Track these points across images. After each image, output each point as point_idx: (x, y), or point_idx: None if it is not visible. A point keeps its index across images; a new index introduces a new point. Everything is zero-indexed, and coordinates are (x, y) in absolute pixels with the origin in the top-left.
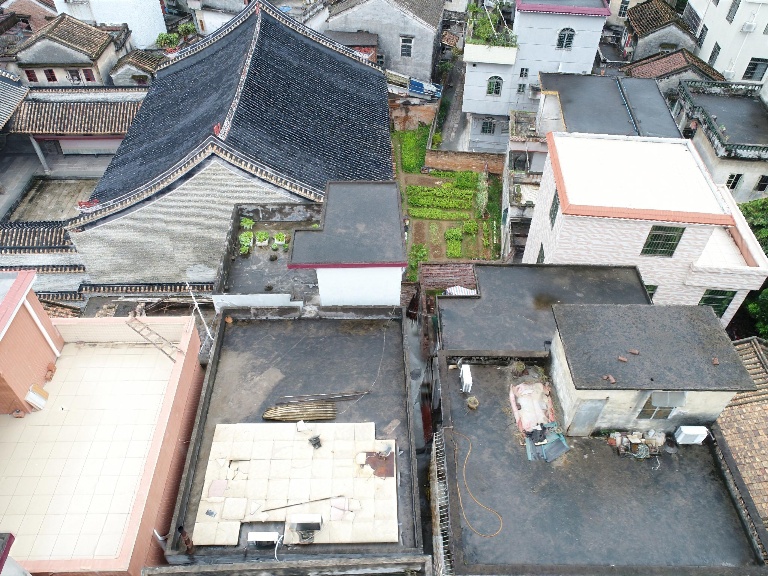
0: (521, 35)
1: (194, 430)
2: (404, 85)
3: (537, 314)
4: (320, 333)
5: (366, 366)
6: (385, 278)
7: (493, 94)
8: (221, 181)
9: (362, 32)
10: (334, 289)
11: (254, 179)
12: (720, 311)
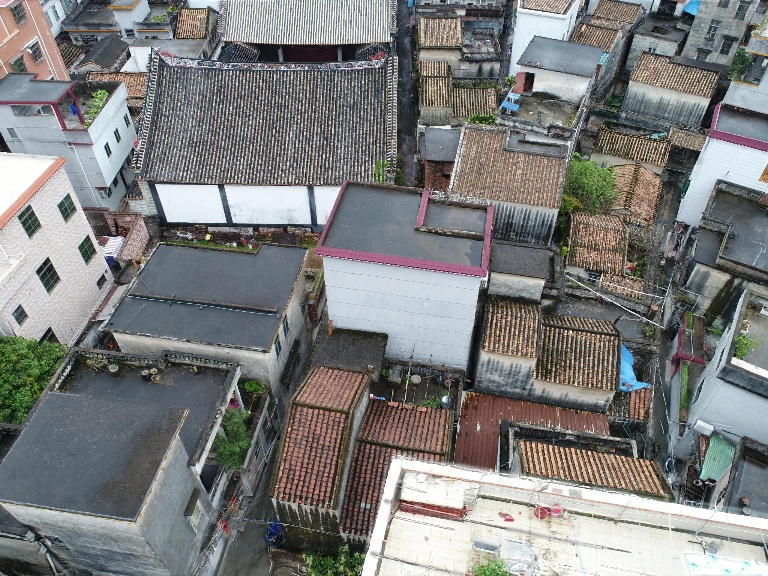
0: None
1: None
2: None
3: None
4: None
5: None
6: None
7: None
8: None
9: None
10: None
11: None
12: None
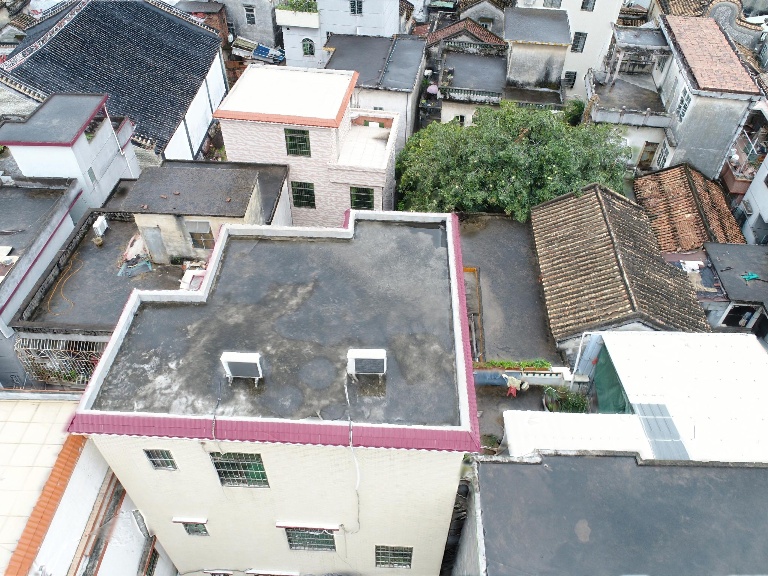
0: (320, 2)
1: None
2: (250, 49)
3: None
4: (11, 196)
5: (31, 216)
6: (63, 157)
7: (309, 55)
8: (5, 101)
9: (212, 2)
10: (29, 166)
11: (30, 100)
12: (370, 207)
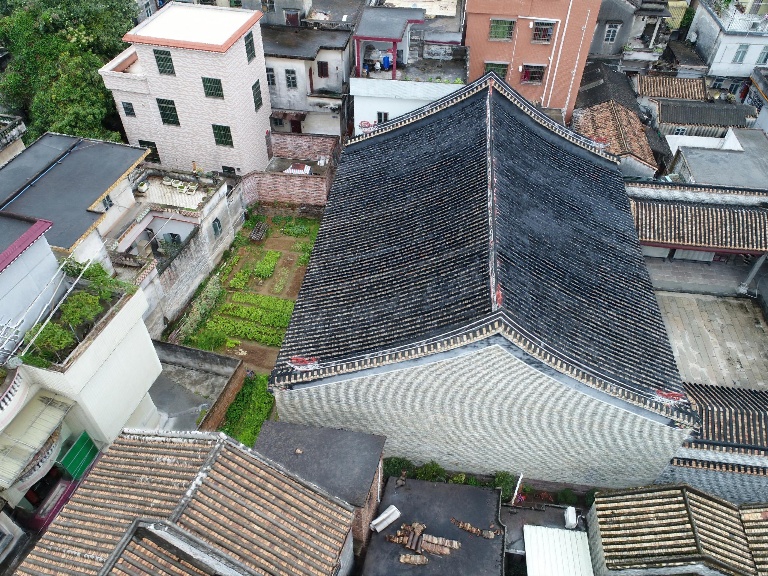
0: None
1: (463, 7)
2: None
3: (293, 40)
4: None
5: None
6: None
7: None
8: None
9: None
10: None
11: None
12: None
